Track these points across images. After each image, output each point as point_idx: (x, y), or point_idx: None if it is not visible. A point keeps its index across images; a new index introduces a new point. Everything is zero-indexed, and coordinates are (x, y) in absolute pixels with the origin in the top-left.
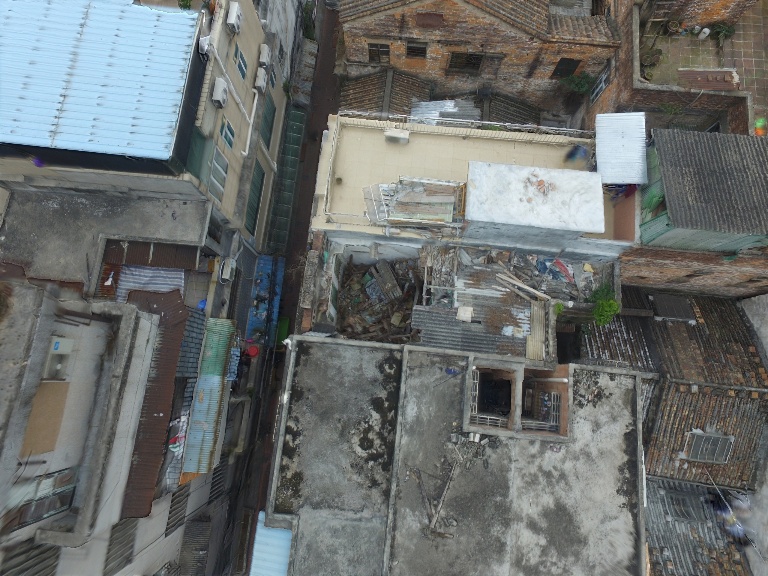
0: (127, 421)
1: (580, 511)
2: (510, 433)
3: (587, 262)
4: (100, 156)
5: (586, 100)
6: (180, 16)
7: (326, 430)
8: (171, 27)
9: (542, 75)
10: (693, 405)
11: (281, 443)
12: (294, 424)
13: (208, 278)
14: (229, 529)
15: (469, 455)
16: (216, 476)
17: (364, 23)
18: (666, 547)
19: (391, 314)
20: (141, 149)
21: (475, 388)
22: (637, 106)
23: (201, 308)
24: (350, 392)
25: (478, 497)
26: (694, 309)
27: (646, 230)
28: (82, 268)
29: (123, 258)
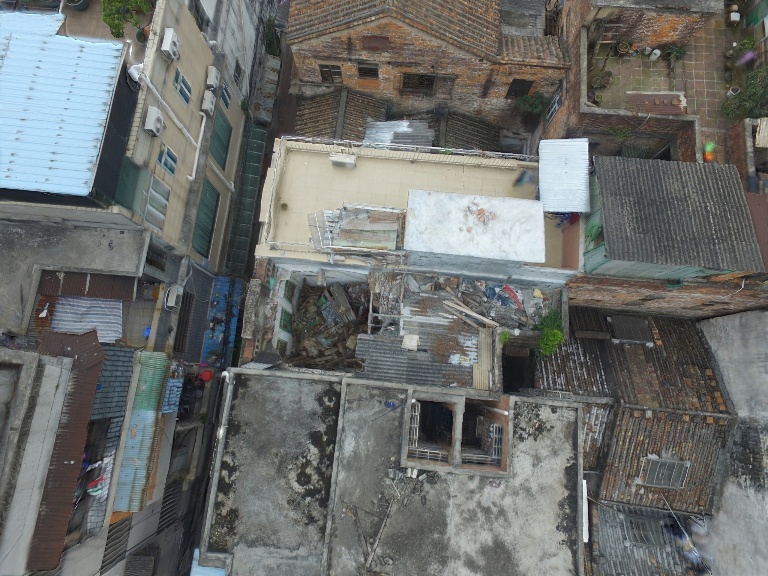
0: (32, 471)
1: (519, 548)
2: (448, 468)
3: (537, 287)
4: (19, 192)
5: (543, 119)
6: (104, 47)
7: (263, 465)
8: (95, 58)
9: (497, 95)
10: (648, 430)
11: (216, 480)
12: (230, 459)
13: (153, 305)
14: (186, 555)
15: (407, 491)
16: (166, 505)
17: (312, 45)
18: (623, 574)
19: (347, 337)
20: (60, 185)
21: (416, 421)
22: (587, 129)
23: (147, 336)
24: (288, 426)
25: (415, 534)
26: (652, 330)
27: (589, 259)
28: (16, 300)
29: (59, 289)
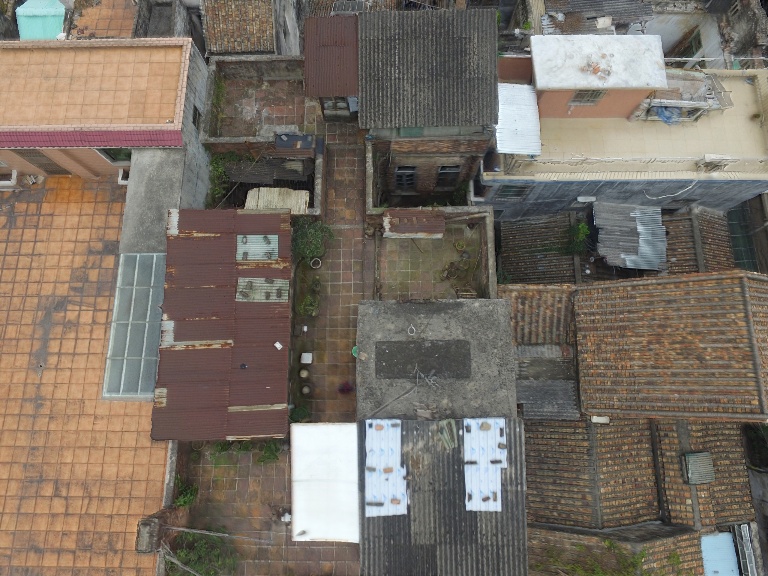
0: None
1: None
2: None
3: None
4: None
5: None
6: None
7: None
8: None
9: None
10: None
11: None
12: None
13: None
14: None
15: None
16: None
17: None
18: None
19: None
20: None
21: None
22: None
23: None
24: None
25: None
26: None
27: None
28: None
29: None
